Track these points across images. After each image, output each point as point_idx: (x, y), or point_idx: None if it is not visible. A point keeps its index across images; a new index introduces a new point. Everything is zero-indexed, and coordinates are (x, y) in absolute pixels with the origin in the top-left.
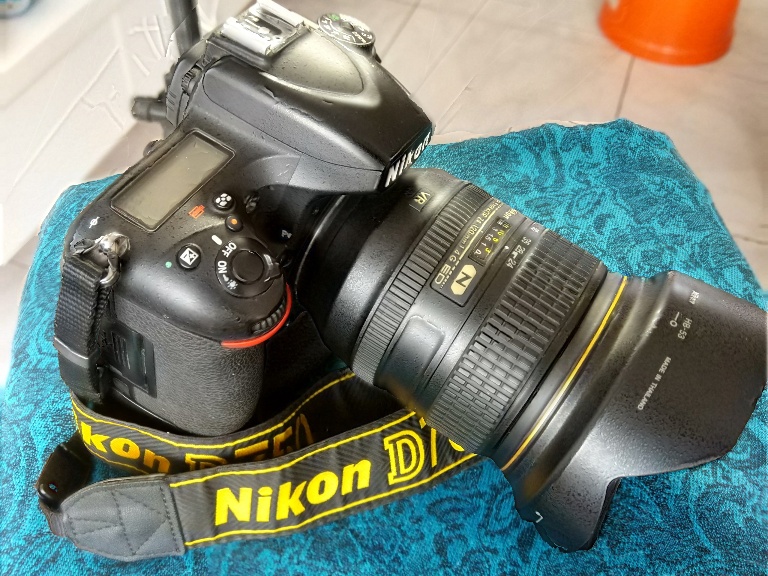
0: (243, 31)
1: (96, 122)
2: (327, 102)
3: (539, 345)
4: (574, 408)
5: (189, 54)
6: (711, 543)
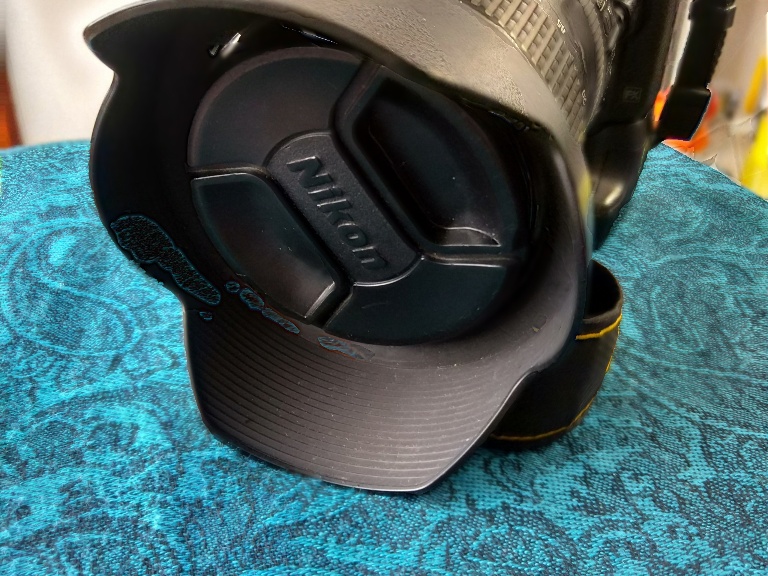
0: None
1: (718, 152)
2: None
3: None
4: None
5: None
6: None
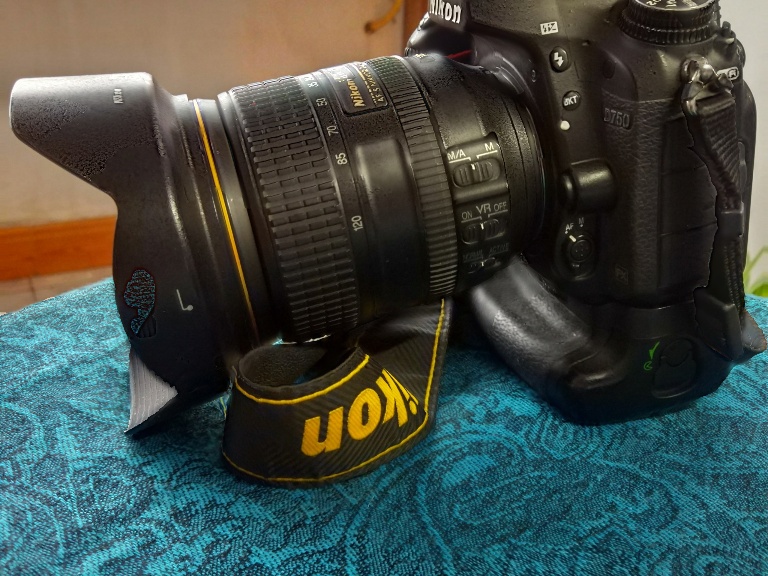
0: None
1: None
2: None
3: None
4: None
5: None
6: (5, 407)
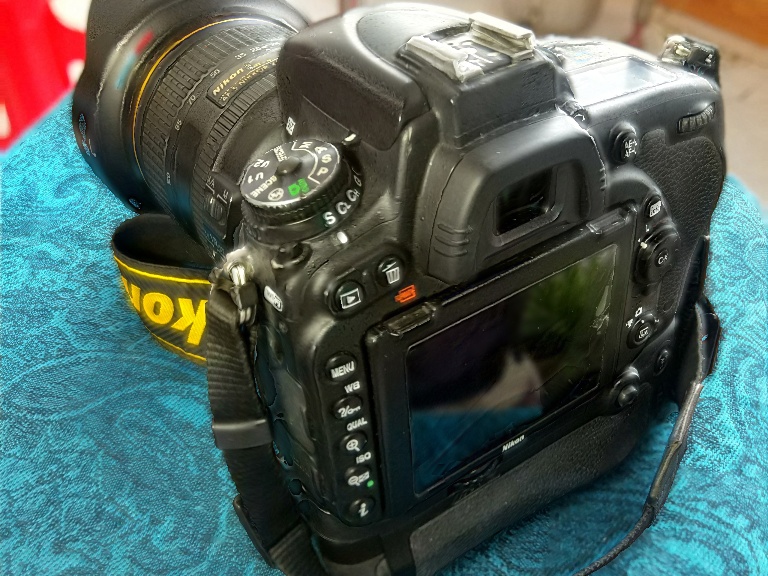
0: (505, 29)
1: None
2: (420, 7)
3: (294, 32)
4: (293, 27)
5: (574, 132)
6: None
